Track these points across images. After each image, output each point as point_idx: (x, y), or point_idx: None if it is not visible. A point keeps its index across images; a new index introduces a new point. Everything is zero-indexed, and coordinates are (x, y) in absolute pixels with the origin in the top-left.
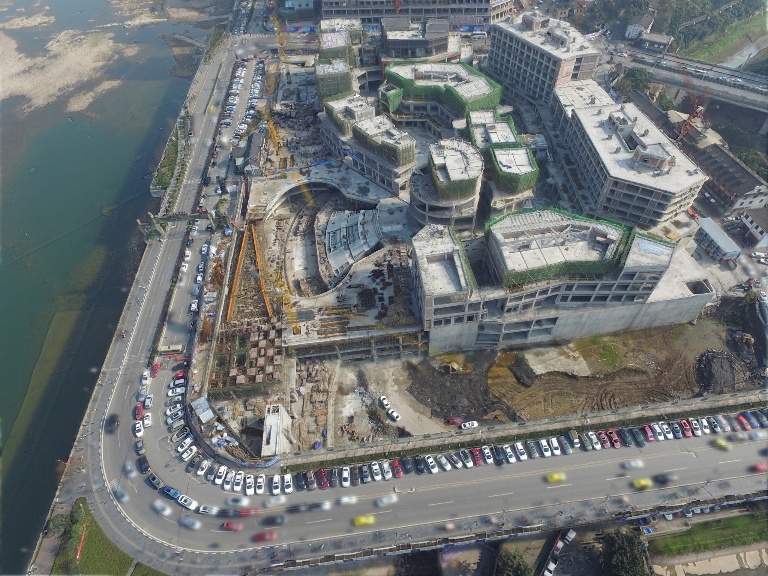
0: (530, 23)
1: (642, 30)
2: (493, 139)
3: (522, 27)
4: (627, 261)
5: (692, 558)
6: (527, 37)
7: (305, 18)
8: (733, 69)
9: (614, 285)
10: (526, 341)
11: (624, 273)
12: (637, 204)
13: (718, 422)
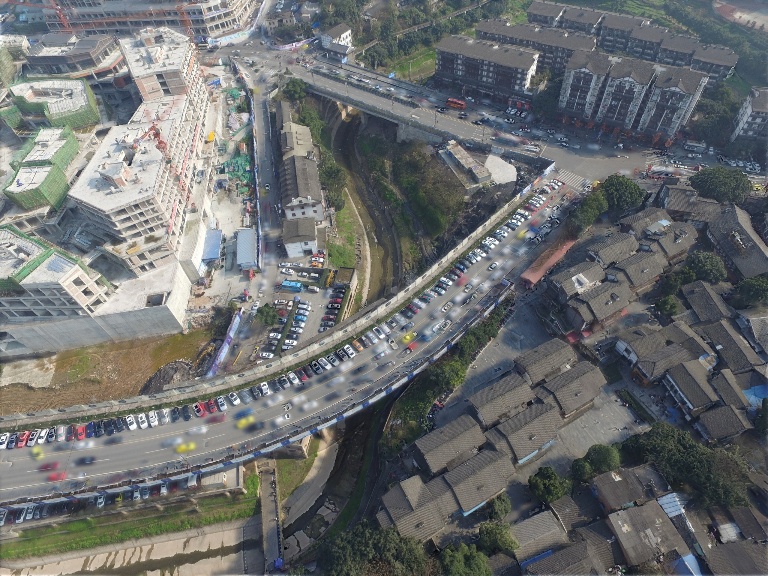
0: (140, 39)
1: (331, 40)
2: (31, 157)
3: (135, 43)
4: (26, 278)
5: (38, 561)
6: (132, 53)
7: (42, 31)
8: (394, 78)
9: (37, 301)
10: (6, 354)
11: (29, 290)
12: (99, 221)
13: (57, 432)
